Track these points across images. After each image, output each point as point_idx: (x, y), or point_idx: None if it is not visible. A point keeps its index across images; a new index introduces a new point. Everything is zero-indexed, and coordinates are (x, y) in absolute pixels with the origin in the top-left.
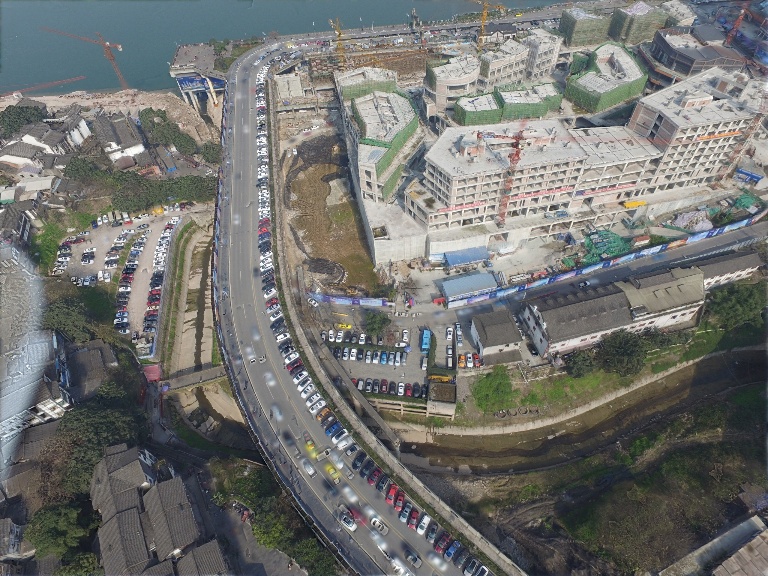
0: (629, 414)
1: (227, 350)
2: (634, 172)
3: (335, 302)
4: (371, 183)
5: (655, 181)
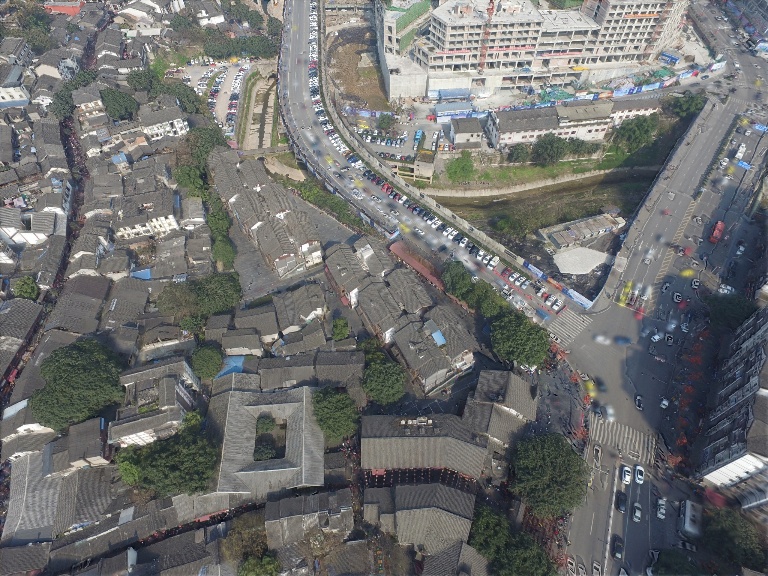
0: (552, 194)
1: (286, 121)
2: (580, 40)
3: (359, 114)
4: (392, 37)
5: (596, 52)
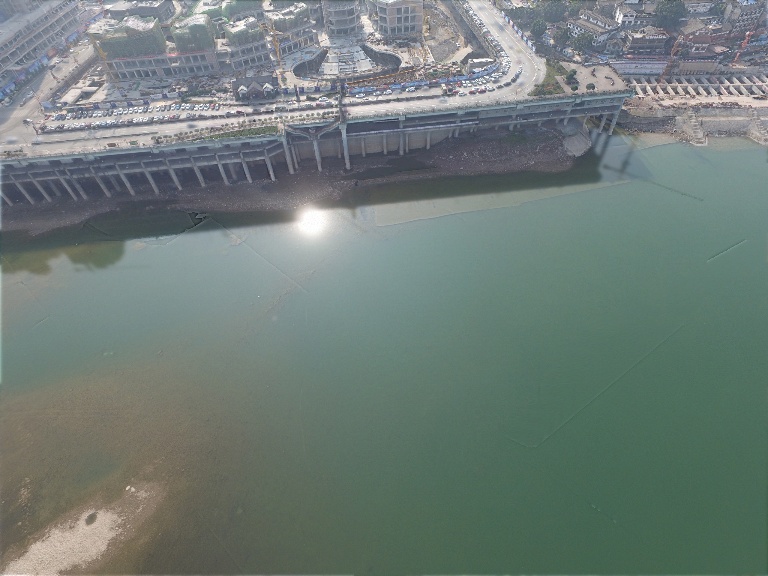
0: None
1: None
2: None
3: None
4: None
5: None
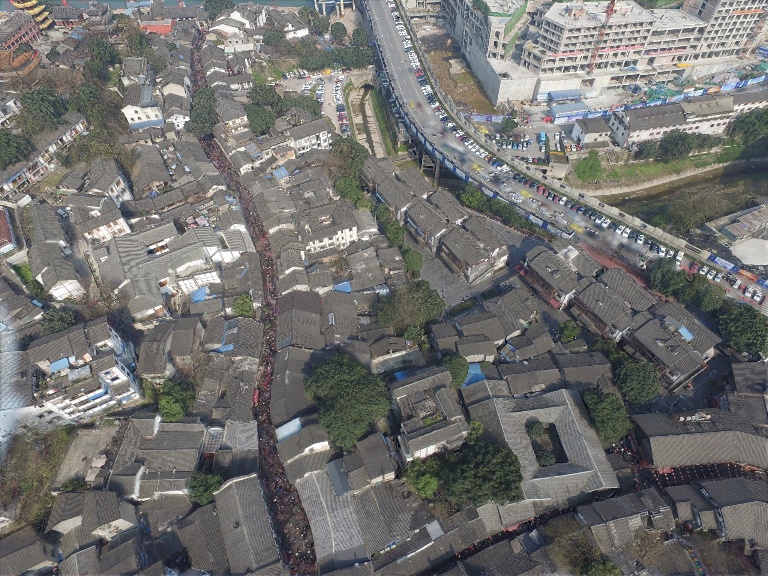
0: (679, 189)
1: None
2: (686, 38)
3: (474, 120)
4: (498, 42)
5: (700, 48)
